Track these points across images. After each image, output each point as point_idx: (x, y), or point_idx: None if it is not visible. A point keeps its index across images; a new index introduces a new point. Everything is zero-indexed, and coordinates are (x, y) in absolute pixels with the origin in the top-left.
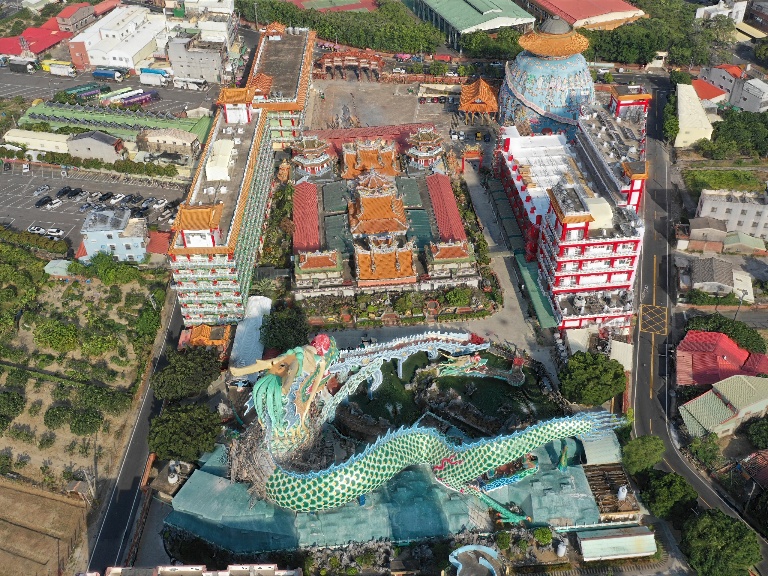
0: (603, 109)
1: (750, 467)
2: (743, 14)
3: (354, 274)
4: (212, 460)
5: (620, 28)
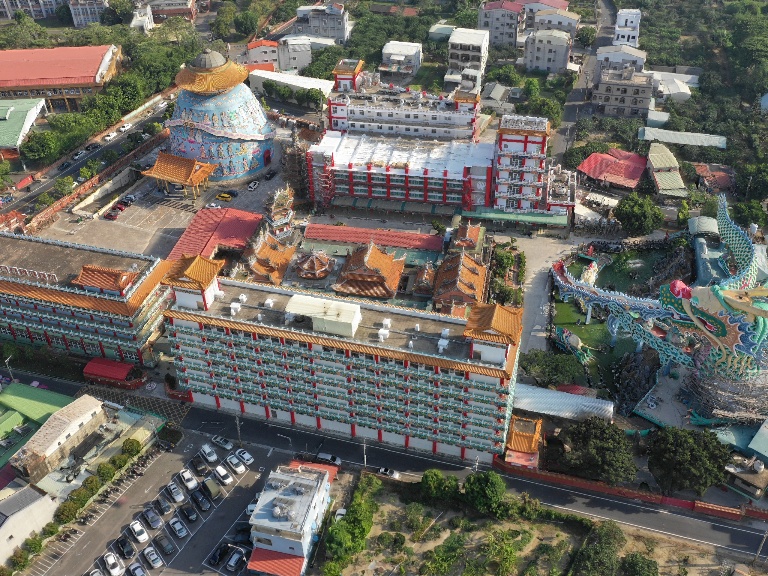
0: (336, 93)
1: (714, 185)
2: (152, 17)
3: None
4: (728, 439)
5: (146, 60)
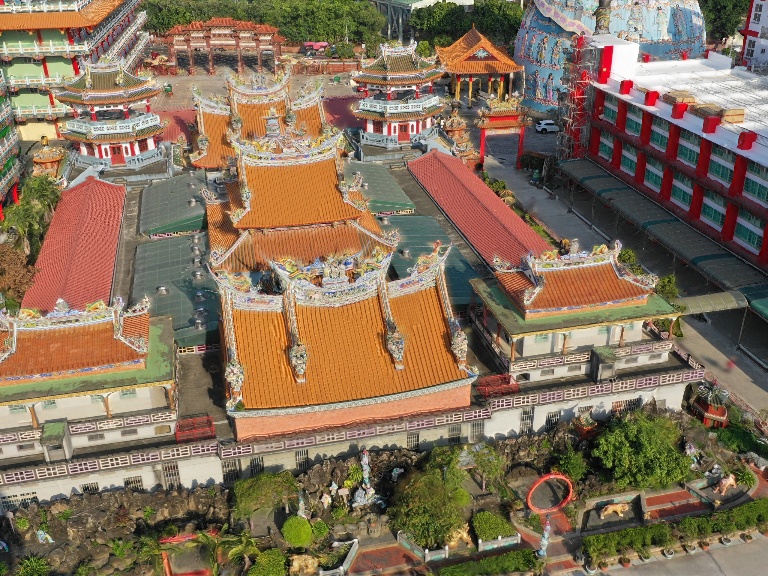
0: None
1: None
2: None
3: (221, 395)
4: None
5: None
